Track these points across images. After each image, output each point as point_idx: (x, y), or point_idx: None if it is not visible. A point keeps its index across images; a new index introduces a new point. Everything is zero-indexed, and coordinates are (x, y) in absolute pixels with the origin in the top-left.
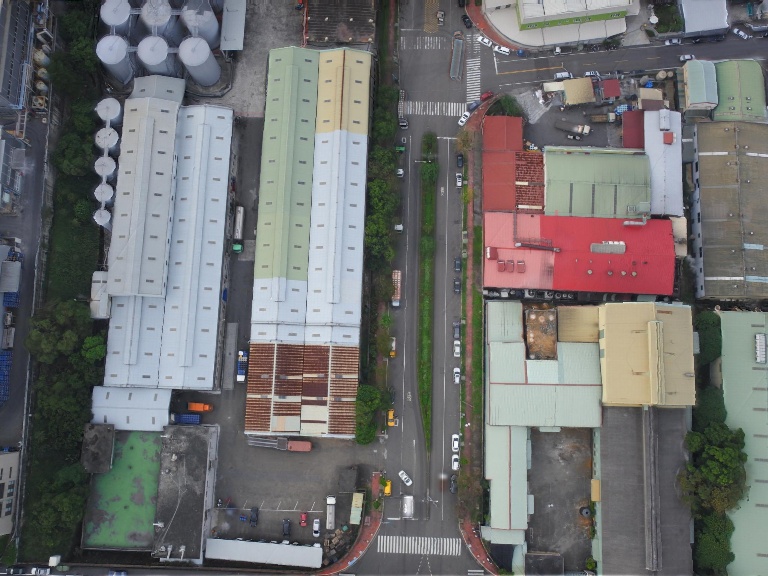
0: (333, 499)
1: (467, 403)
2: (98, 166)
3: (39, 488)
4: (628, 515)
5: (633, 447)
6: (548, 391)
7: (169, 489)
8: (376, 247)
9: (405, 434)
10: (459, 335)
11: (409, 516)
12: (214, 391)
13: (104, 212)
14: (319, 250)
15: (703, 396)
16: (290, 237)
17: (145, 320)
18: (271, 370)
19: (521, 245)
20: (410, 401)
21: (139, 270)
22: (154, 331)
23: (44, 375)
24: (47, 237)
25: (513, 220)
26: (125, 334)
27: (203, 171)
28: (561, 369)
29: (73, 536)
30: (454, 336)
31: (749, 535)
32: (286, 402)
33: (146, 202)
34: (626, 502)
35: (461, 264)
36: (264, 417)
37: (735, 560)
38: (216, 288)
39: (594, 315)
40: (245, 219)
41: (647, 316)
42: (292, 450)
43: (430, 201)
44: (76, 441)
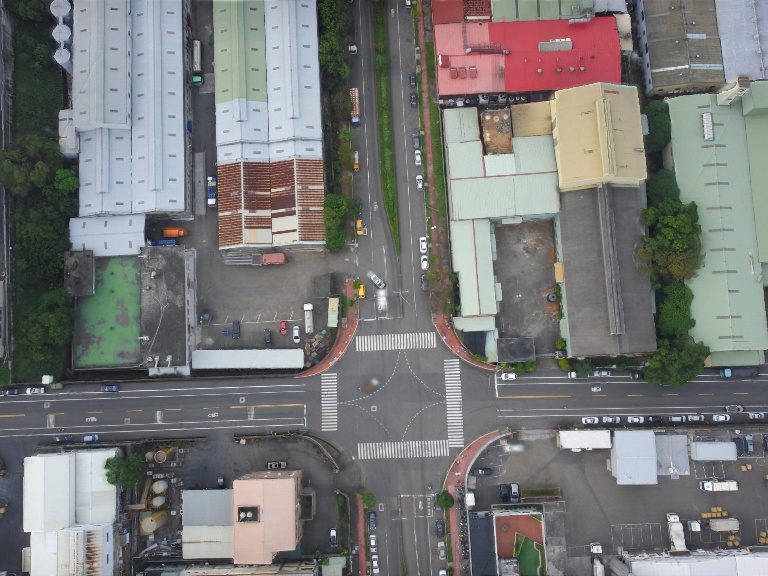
0: (310, 305)
1: (431, 207)
2: (53, 8)
3: (26, 312)
4: (591, 288)
5: (591, 225)
6: (506, 182)
7: (151, 305)
8: (331, 64)
9: (374, 241)
10: (419, 145)
11: (384, 316)
12: (187, 218)
13: (64, 51)
14: (276, 71)
15: (656, 177)
16: (247, 60)
17: (113, 151)
18: (239, 187)
19: (471, 50)
20: (377, 210)
21: (102, 100)
22: (123, 161)
23: (20, 208)
24: (11, 82)
25: (462, 29)
26: (95, 165)
27: (157, 5)
28: (518, 161)
29: (64, 360)
30: (414, 146)
31: (708, 301)
32: (256, 216)
33: (103, 36)
34: (588, 277)
35: (416, 79)
36: (236, 231)
37: (696, 325)
38: (179, 116)
39: (546, 109)
40: (203, 53)
41: (595, 97)
42: (266, 262)
43: (381, 22)
44: (57, 268)
